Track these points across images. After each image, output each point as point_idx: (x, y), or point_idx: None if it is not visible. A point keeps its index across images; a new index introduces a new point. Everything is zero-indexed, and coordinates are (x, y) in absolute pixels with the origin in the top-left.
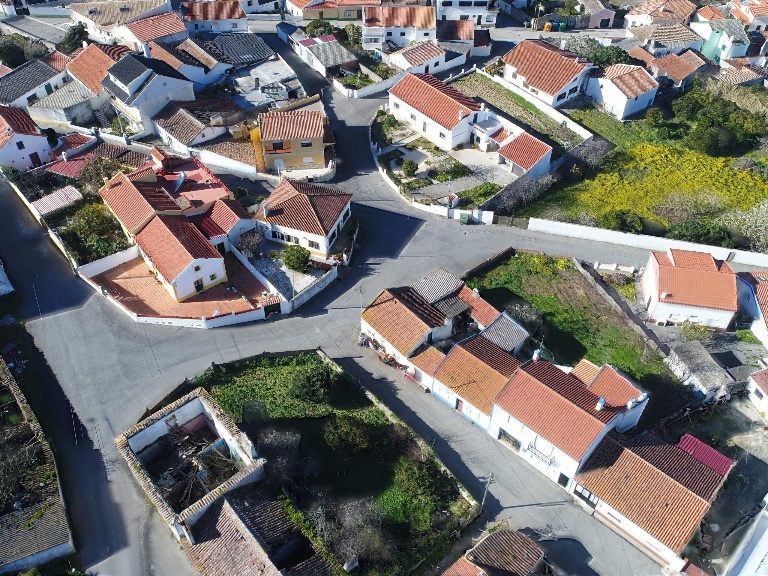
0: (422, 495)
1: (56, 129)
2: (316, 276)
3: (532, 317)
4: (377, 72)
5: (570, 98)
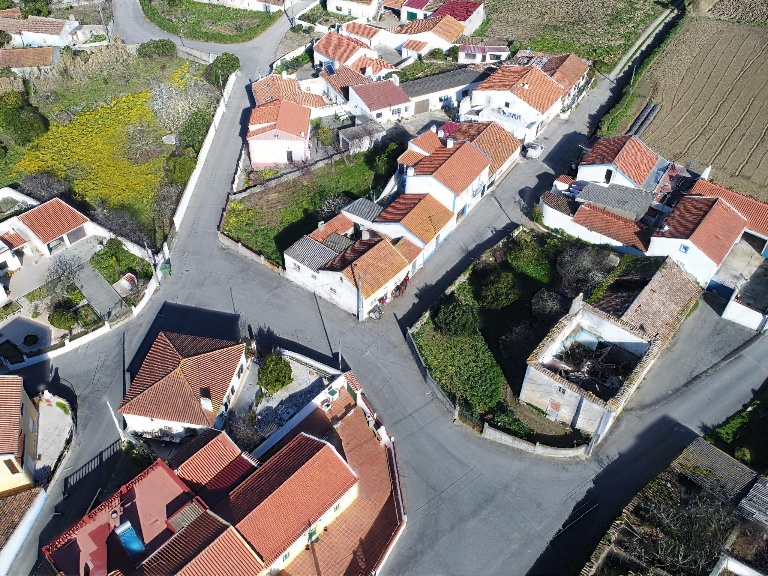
0: None
1: None
2: None
3: None
4: None
5: None
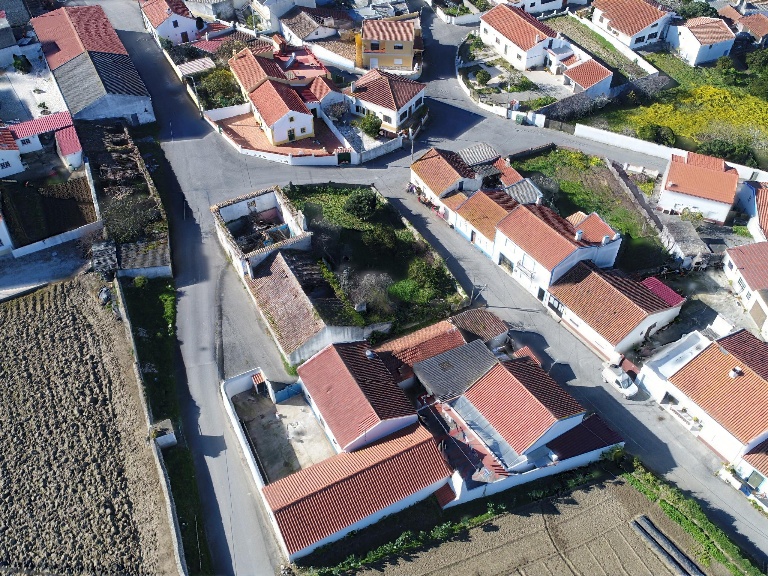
0: (428, 288)
1: None
2: (384, 142)
3: (551, 186)
4: (477, 5)
5: (649, 43)
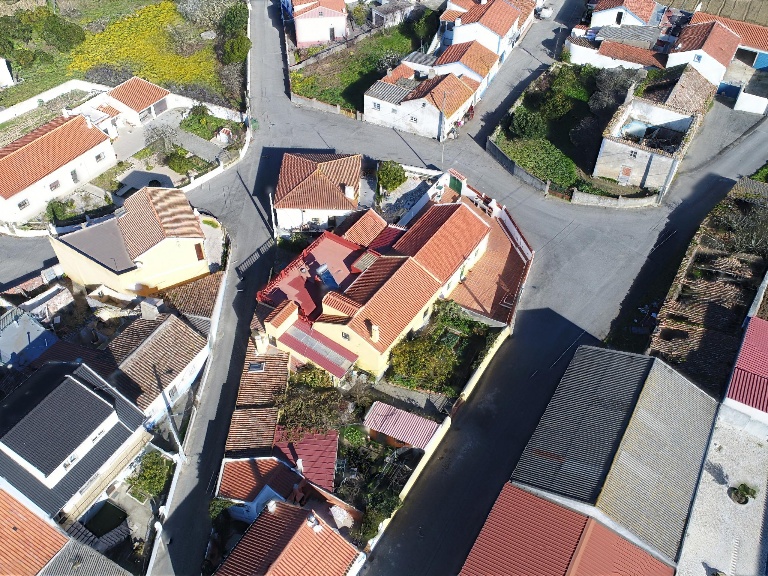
0: None
1: None
2: None
3: None
4: None
5: None
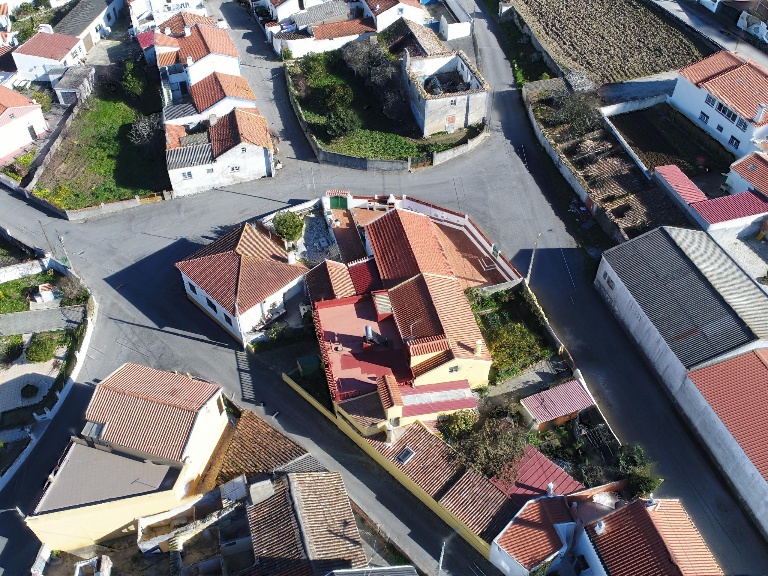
0: None
1: None
2: None
3: None
4: None
5: None
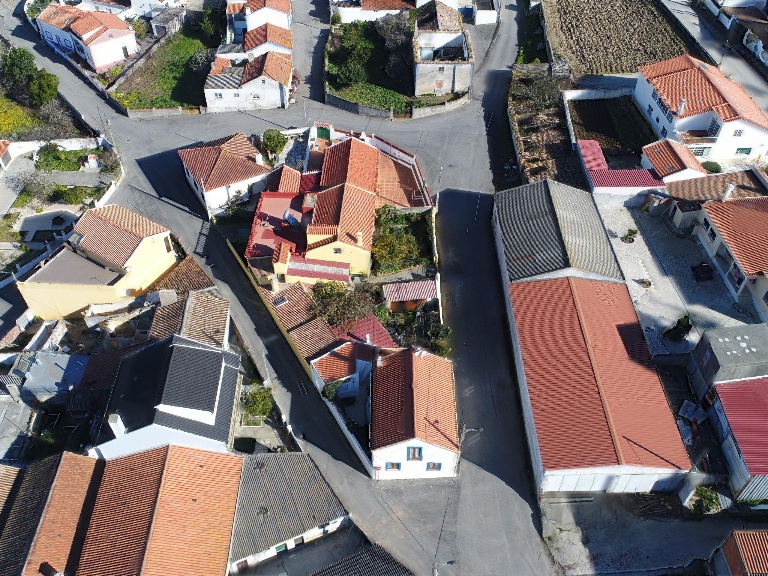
0: None
1: (333, 477)
2: None
3: None
4: None
5: None
